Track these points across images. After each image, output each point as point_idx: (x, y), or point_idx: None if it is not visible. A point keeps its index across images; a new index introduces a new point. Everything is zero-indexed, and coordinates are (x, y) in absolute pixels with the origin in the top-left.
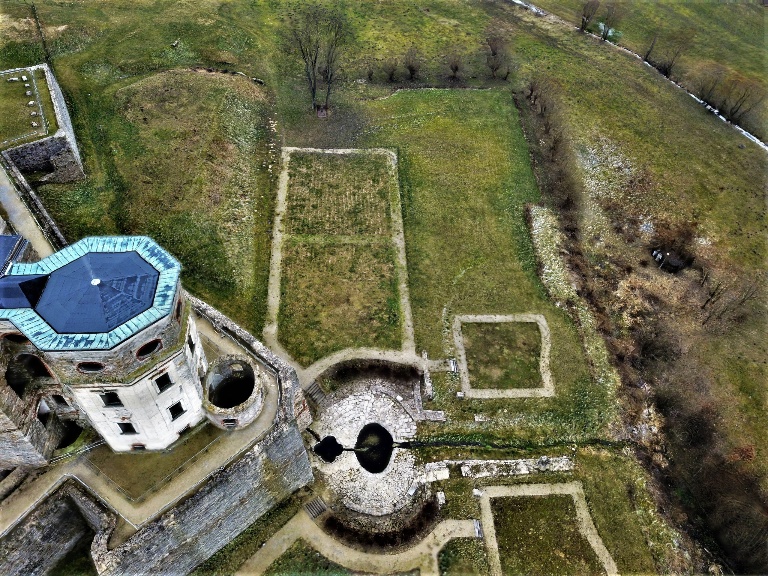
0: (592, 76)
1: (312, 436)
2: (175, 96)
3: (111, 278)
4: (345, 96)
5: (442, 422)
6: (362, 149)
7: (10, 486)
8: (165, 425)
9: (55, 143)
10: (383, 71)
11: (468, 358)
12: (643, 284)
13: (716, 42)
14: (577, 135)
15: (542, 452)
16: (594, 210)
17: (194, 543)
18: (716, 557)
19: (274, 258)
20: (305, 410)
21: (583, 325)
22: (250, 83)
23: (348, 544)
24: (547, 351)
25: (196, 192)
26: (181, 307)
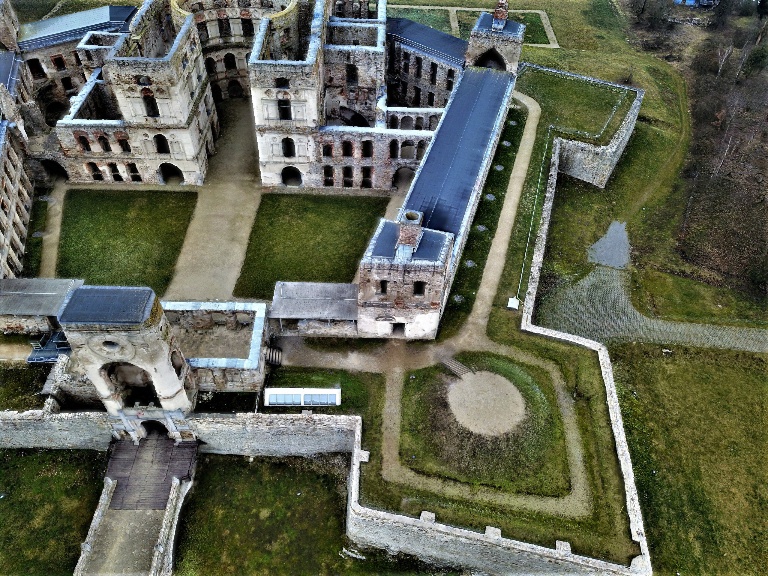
0: None
1: None
2: None
3: None
4: None
5: None
6: (61, 0)
7: None
8: None
9: None
10: None
11: None
12: None
13: None
14: None
15: None
16: None
17: None
18: None
19: None
20: None
21: None
22: None
23: None
24: None
25: None
26: None
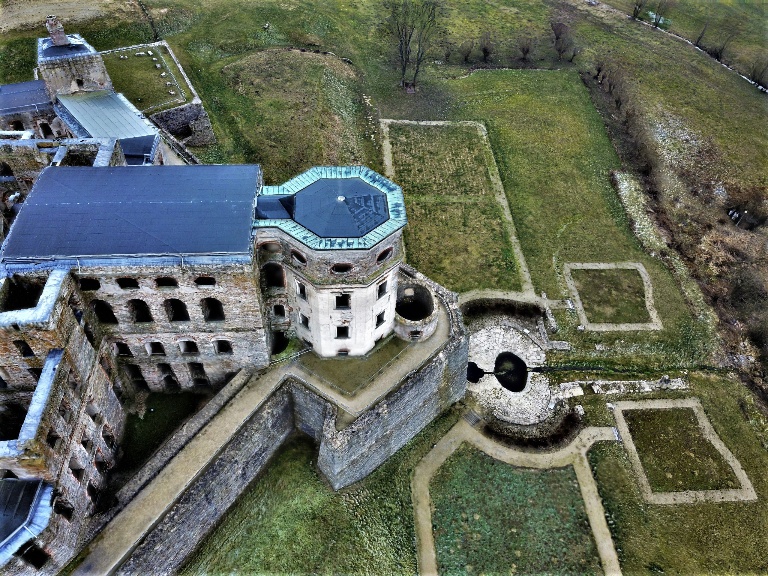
0: (650, 59)
1: None
2: (279, 72)
3: (352, 196)
4: (427, 75)
5: (567, 351)
6: (453, 121)
7: (240, 383)
8: (371, 332)
9: (193, 109)
10: (457, 53)
11: (582, 298)
12: (724, 239)
13: (760, 29)
14: (644, 111)
15: (659, 375)
16: (670, 176)
17: (390, 436)
18: None
19: None
20: None
21: (678, 272)
22: (341, 62)
23: (507, 446)
24: (650, 293)
25: (318, 155)
26: None
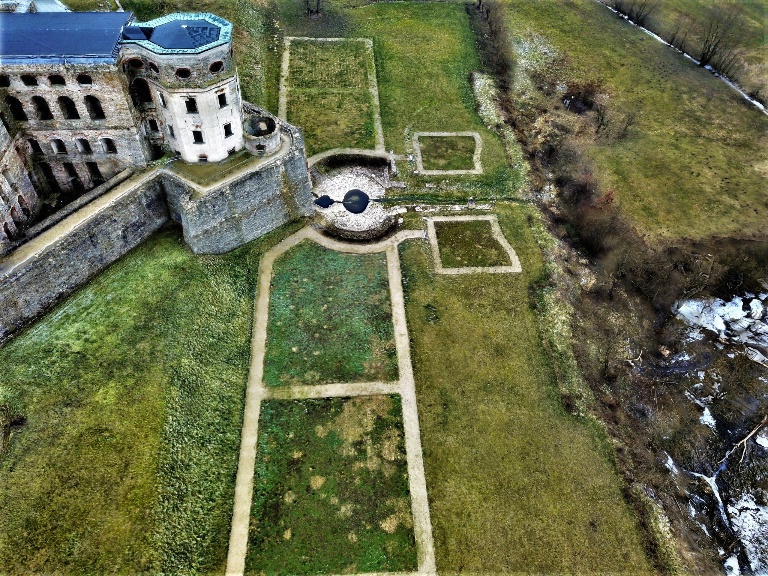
0: None
1: (313, 195)
2: None
3: (193, 26)
4: (332, 6)
5: (403, 188)
6: (346, 38)
7: (124, 176)
8: (221, 139)
9: None
10: None
11: (422, 154)
12: (554, 119)
13: None
14: (515, 32)
15: None
16: (523, 77)
17: (239, 221)
18: (585, 256)
19: (281, 101)
20: (308, 172)
21: (507, 138)
22: None
23: (338, 241)
24: (479, 151)
25: None
26: (232, 54)
